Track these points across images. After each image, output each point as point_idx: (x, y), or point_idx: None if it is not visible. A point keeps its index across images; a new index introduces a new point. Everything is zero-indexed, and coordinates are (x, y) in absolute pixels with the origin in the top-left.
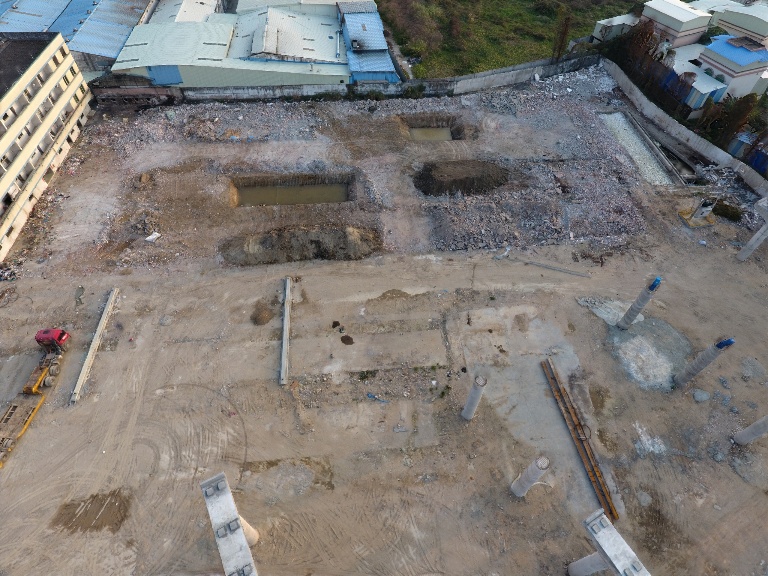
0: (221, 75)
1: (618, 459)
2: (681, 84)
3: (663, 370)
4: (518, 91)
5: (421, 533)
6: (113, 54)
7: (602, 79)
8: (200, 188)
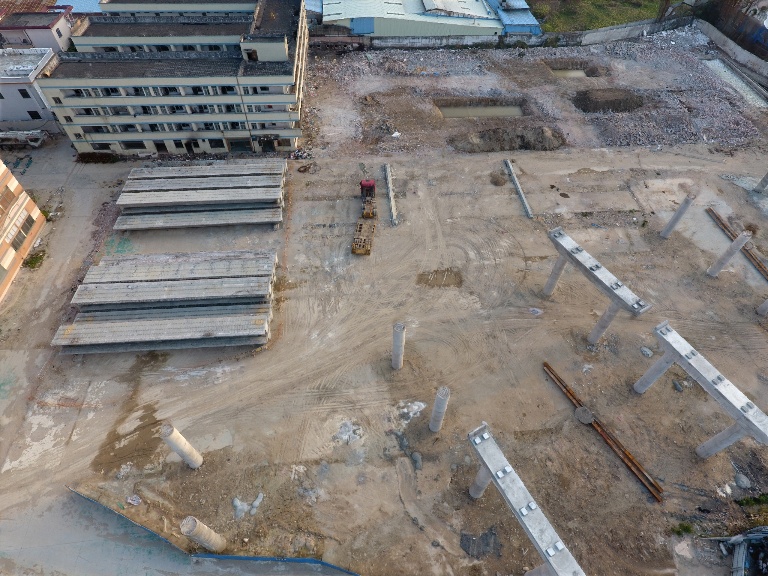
0: (405, 26)
1: None
2: None
3: None
4: None
5: (655, 292)
6: (318, 10)
7: (697, 35)
8: (413, 106)
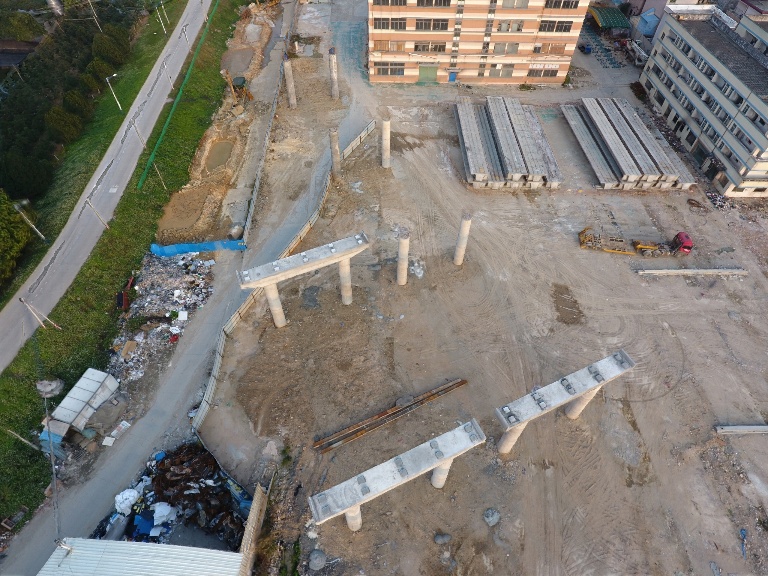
0: None
1: None
2: None
3: None
4: None
5: None
6: None
7: None
8: None
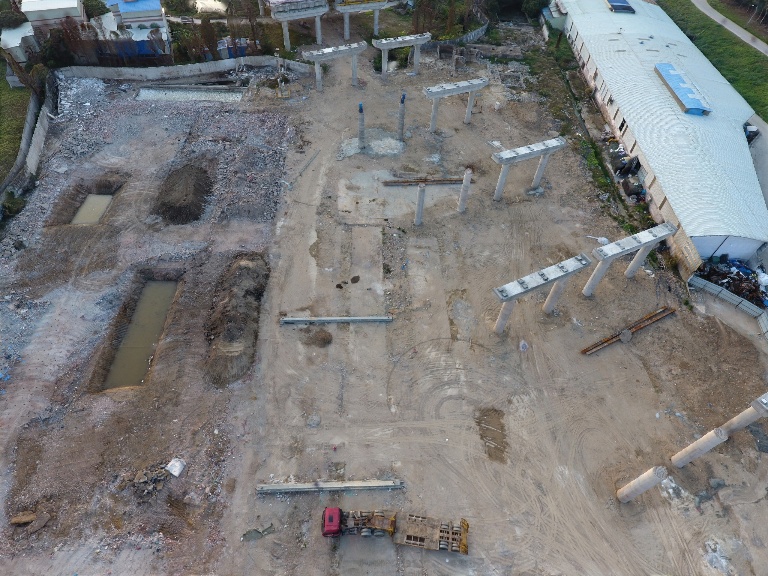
0: None
1: (443, 171)
2: (156, 41)
3: (393, 141)
4: (64, 134)
5: (486, 251)
6: None
7: (83, 83)
8: (90, 430)
